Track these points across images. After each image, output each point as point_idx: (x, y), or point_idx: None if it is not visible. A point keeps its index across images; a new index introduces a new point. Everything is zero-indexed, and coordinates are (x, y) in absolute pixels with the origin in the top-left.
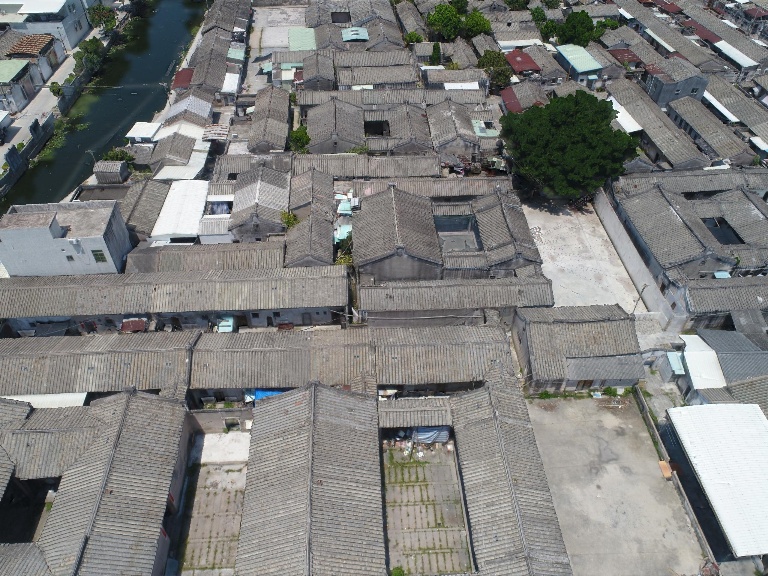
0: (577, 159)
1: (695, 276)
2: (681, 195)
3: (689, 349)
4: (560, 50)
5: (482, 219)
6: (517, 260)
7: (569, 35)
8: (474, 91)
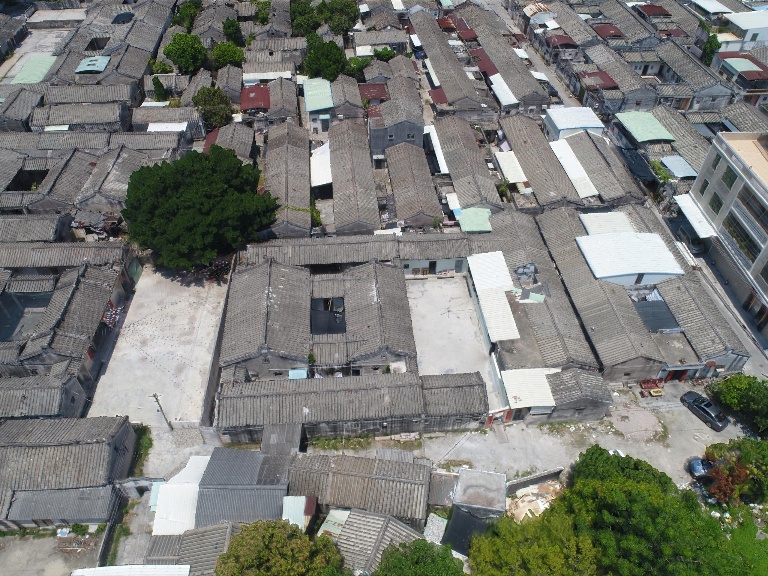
0: (181, 228)
1: (268, 374)
2: (304, 269)
3: (173, 480)
4: (305, 84)
5: (55, 298)
6: (48, 355)
7: (314, 68)
8: (167, 135)
